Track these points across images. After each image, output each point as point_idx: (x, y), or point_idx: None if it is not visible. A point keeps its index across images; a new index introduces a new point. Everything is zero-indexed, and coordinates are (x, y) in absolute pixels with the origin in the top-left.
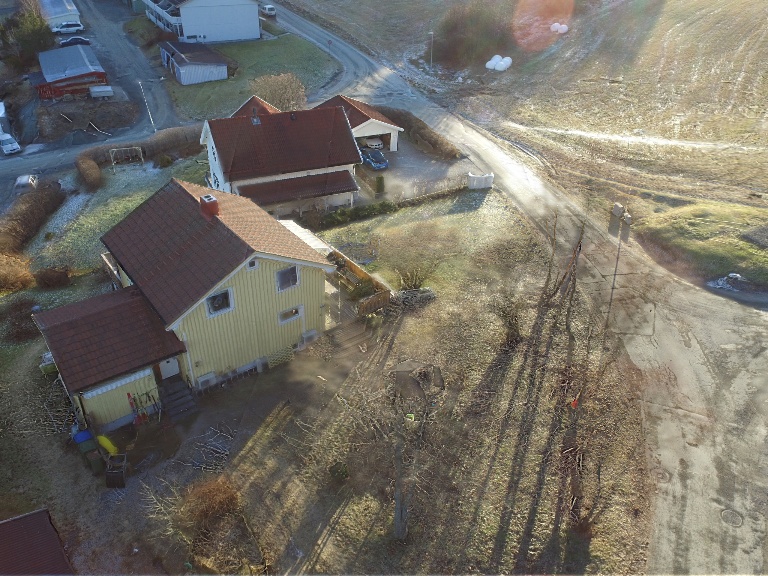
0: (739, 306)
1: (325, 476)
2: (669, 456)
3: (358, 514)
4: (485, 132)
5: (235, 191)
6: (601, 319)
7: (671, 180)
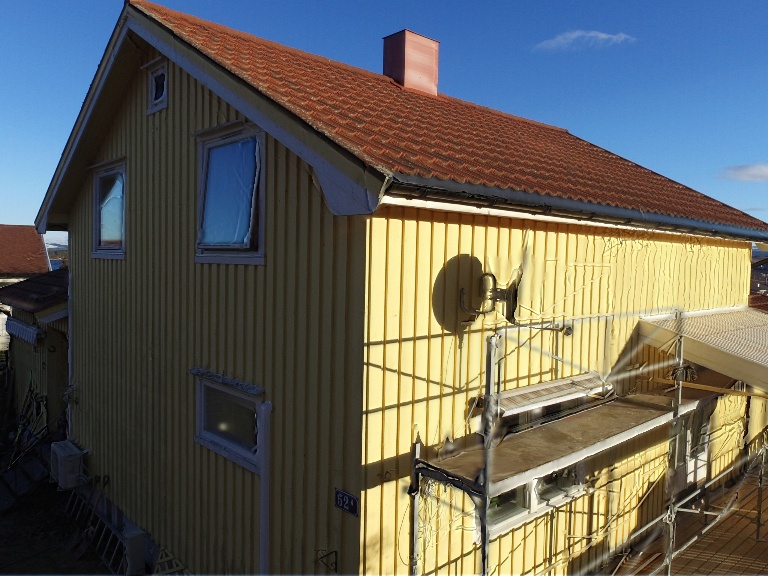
0: None
1: None
2: None
3: None
4: None
5: None
6: None
7: None
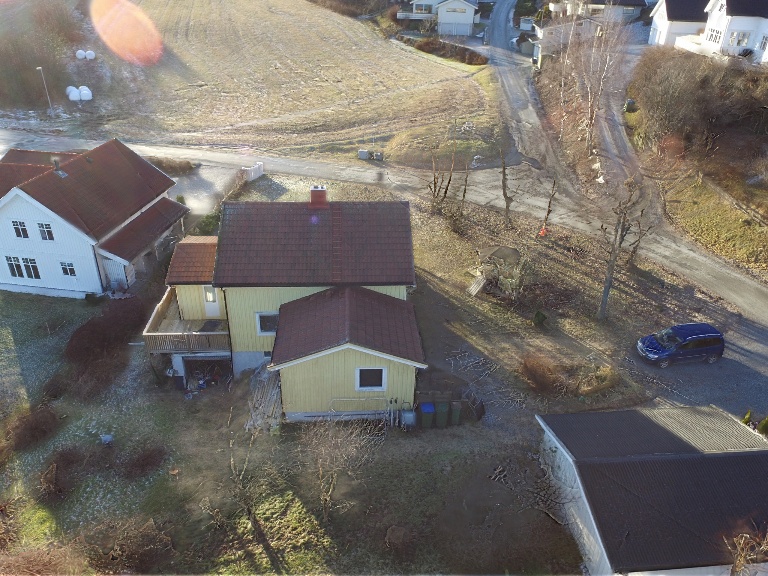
0: (500, 169)
1: (534, 329)
2: (593, 231)
3: (574, 328)
4: (173, 146)
5: (98, 252)
6: (468, 203)
7: (358, 129)
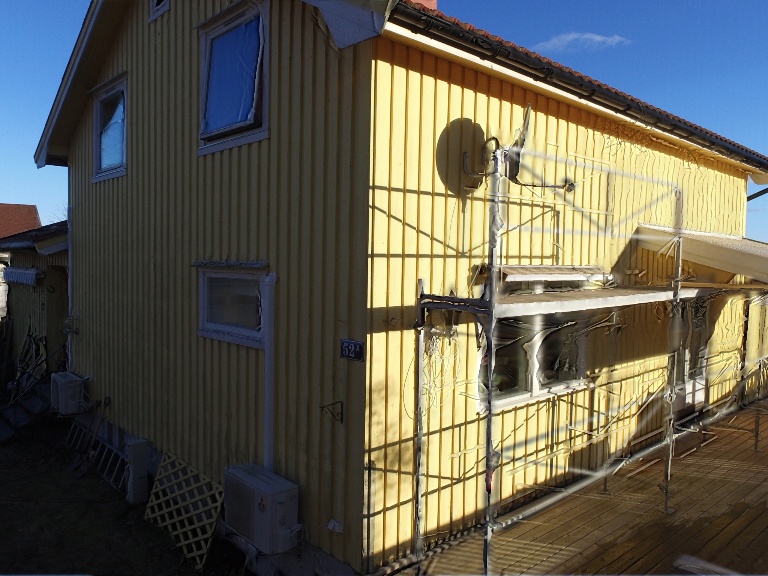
0: None
1: None
2: None
3: None
4: None
5: None
6: None
7: None
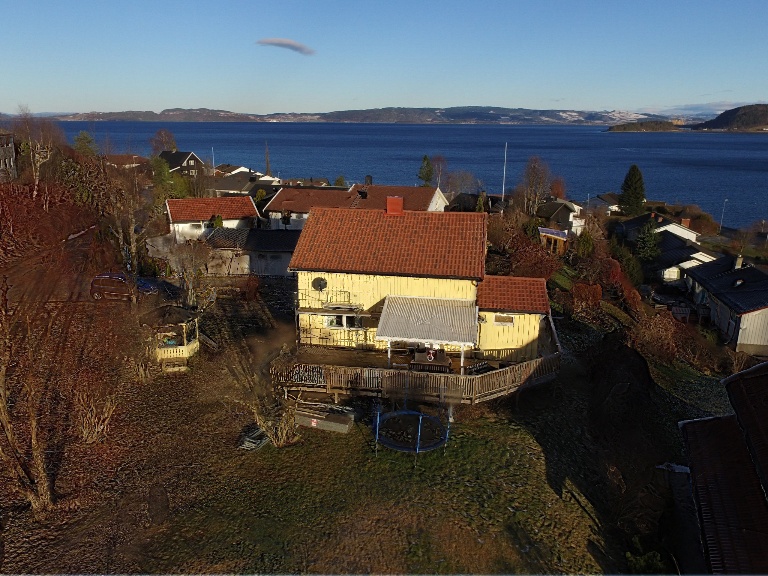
0: None
1: (205, 317)
2: None
3: None
4: None
5: None
6: None
7: None
